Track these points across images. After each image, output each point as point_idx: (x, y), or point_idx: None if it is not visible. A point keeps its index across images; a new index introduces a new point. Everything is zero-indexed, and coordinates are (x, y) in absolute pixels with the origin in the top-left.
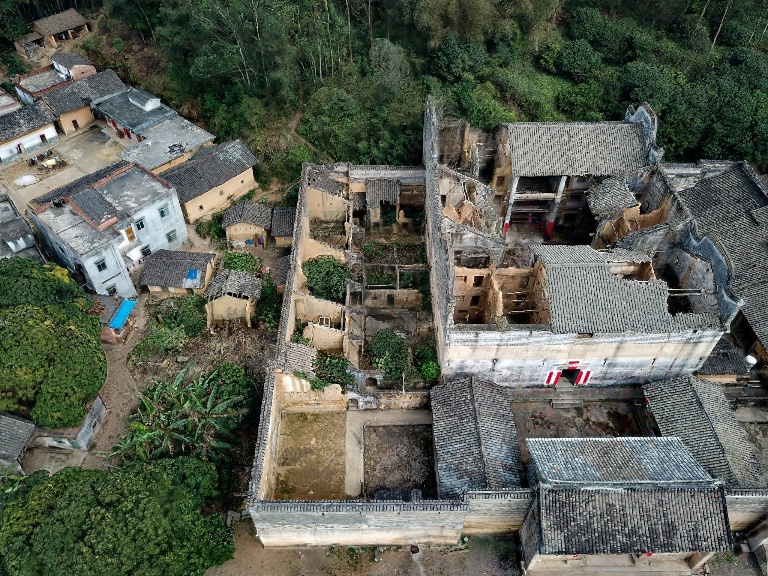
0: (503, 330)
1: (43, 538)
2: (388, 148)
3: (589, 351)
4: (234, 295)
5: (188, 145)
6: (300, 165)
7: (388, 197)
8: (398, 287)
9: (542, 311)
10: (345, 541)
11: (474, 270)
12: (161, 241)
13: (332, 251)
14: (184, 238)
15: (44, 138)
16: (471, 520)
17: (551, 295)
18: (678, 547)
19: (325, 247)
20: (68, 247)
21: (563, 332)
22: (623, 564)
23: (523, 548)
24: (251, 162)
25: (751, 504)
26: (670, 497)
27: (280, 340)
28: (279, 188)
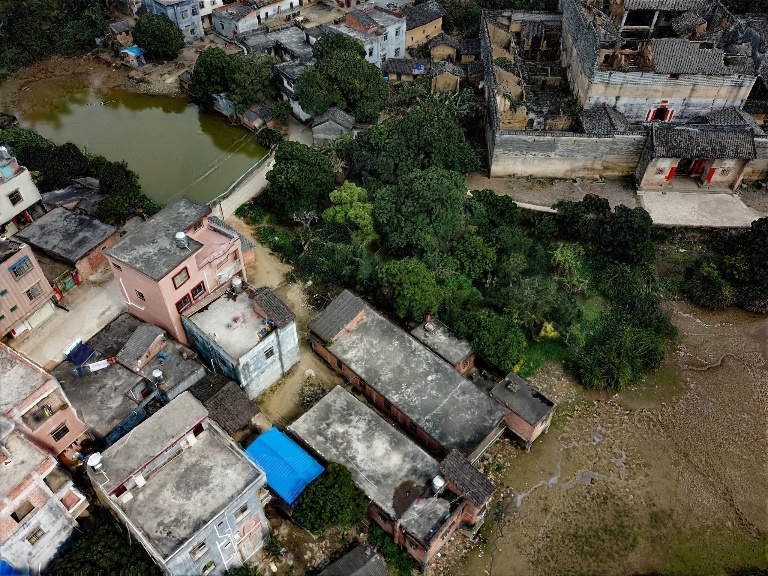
0: (627, 71)
1: (398, 134)
2: (535, 5)
3: (675, 92)
4: (450, 73)
5: (398, 4)
6: (473, 18)
7: (537, 32)
8: (549, 75)
9: (648, 66)
10: (537, 173)
11: (605, 50)
12: (391, 54)
13: (507, 55)
14: (402, 56)
15: (291, 5)
16: (609, 160)
17: (655, 54)
18: (727, 156)
19: (503, 51)
20: (354, 39)
21: (662, 72)
22: (694, 188)
23: (637, 179)
24: (443, 13)
25: (767, 149)
26: (723, 134)
27: (494, 77)
28: (458, 33)
